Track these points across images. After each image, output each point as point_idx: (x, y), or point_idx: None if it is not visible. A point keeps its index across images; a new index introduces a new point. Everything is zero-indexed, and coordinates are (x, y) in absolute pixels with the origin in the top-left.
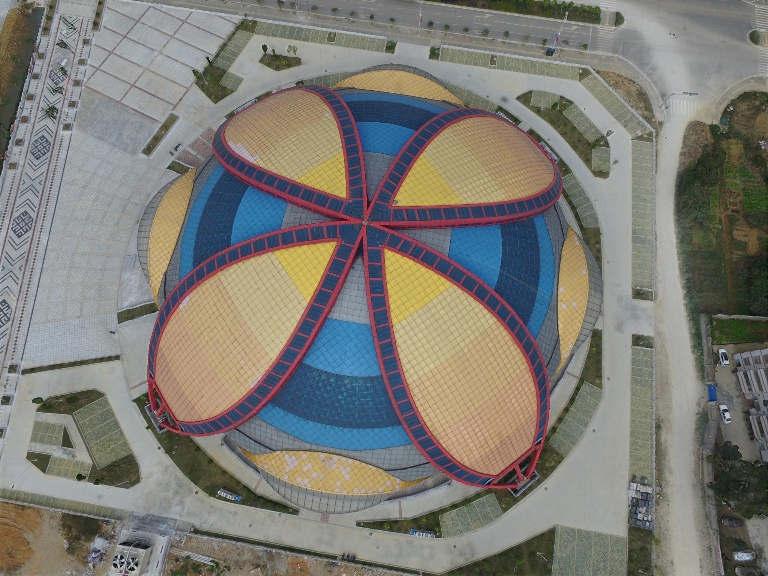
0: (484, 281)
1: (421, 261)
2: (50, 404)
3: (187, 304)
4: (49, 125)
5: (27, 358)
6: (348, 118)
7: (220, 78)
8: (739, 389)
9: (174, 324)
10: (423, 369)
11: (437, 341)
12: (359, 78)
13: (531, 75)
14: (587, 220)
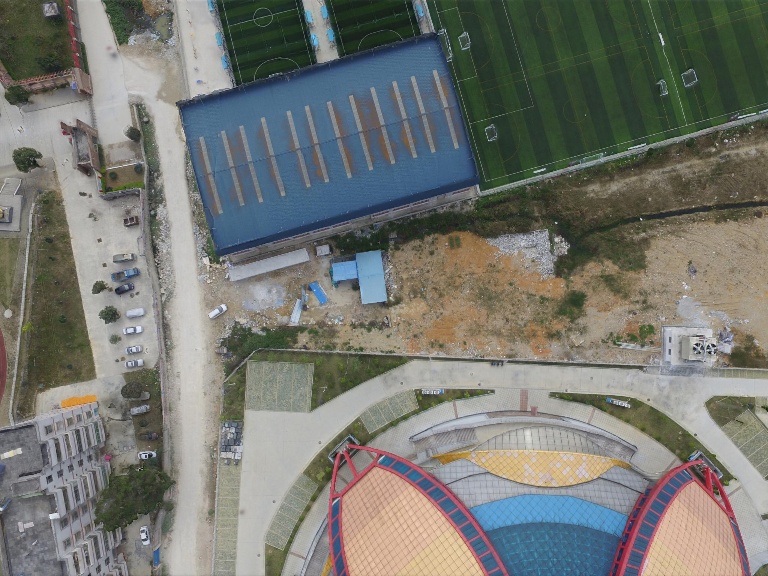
0: None
1: None
2: None
3: None
4: None
5: None
6: None
7: None
8: (129, 562)
9: None
10: None
11: None
12: None
13: None
14: None
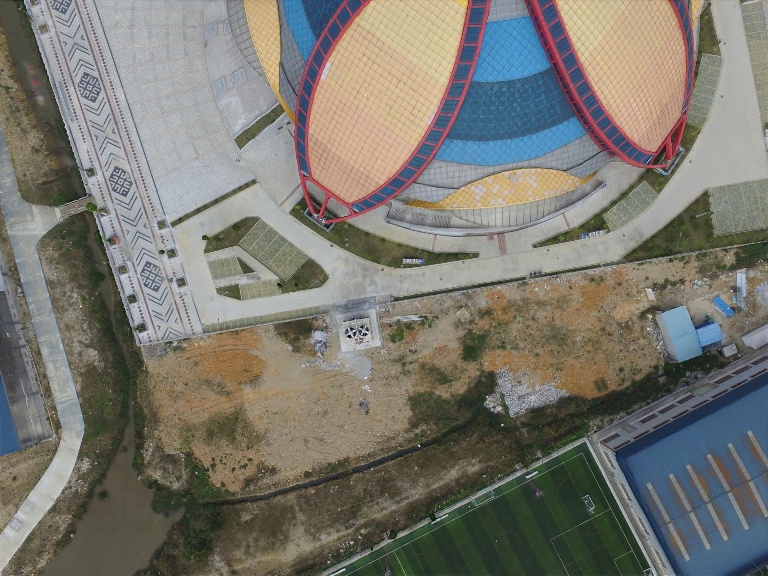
0: None
1: None
2: (214, 242)
3: (330, 71)
4: None
5: (169, 211)
6: None
7: None
8: None
9: (321, 100)
10: (592, 44)
11: (600, 9)
12: None
13: None
14: None
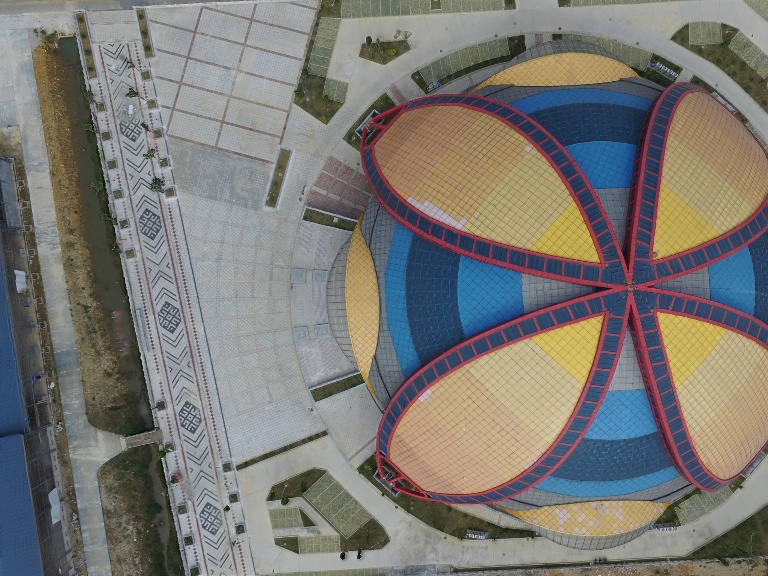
0: (744, 310)
1: (696, 316)
2: (279, 493)
3: (430, 397)
4: (148, 195)
5: (236, 454)
6: (559, 151)
7: (321, 89)
8: None
9: (415, 416)
10: (704, 420)
11: (717, 391)
12: (517, 71)
13: (683, 2)
14: None
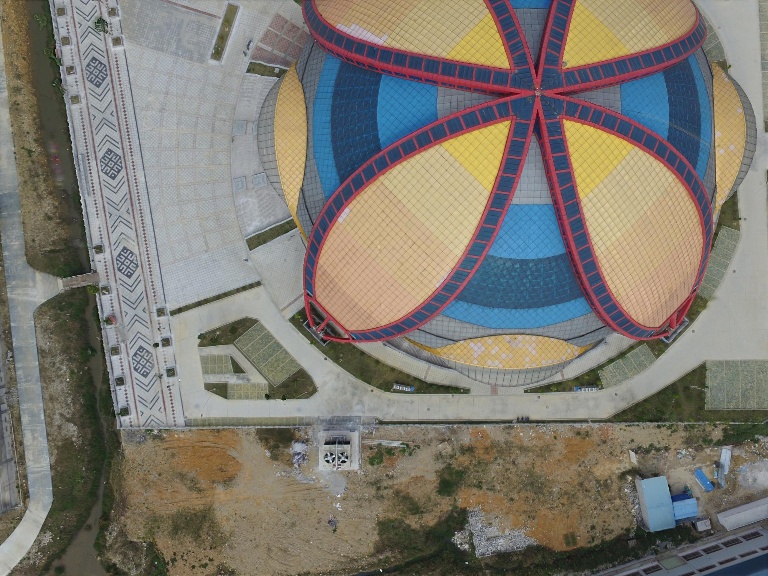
0: None
1: (602, 126)
2: (210, 338)
3: (348, 216)
4: (95, 43)
5: (170, 300)
6: None
7: None
8: None
9: (335, 239)
10: (610, 239)
11: (623, 209)
12: None
13: None
14: (712, 53)
